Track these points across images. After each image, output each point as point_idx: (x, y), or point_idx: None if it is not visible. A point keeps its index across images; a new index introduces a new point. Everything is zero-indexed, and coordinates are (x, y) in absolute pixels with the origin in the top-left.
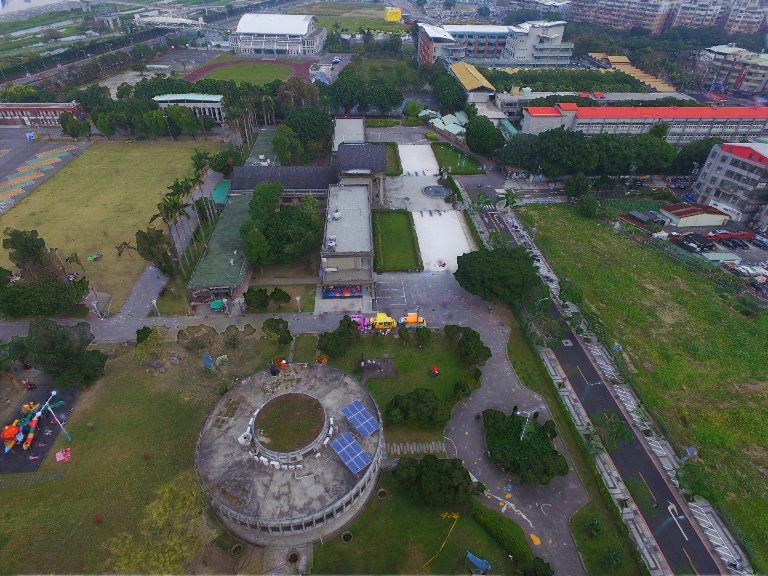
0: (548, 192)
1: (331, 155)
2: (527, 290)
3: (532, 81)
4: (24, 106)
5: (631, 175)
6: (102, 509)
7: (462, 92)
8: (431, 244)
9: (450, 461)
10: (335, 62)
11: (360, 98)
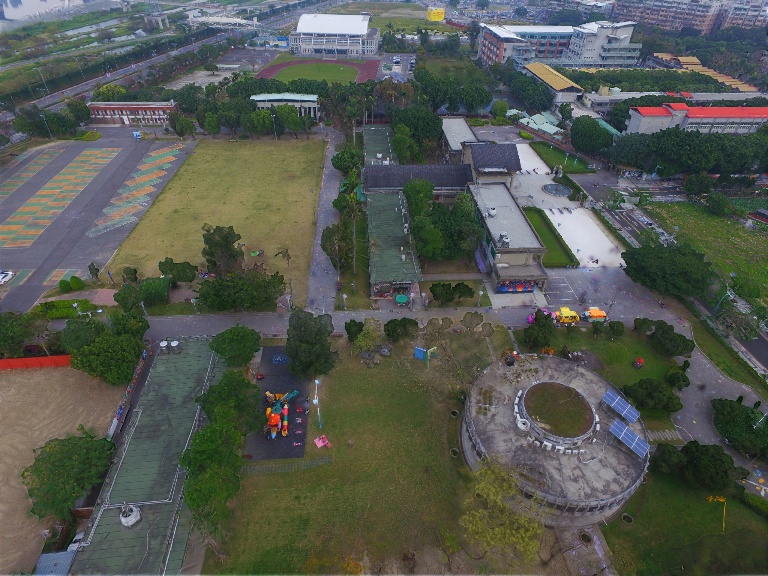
0: (665, 190)
1: (444, 154)
2: (708, 285)
3: (614, 81)
4: (123, 105)
5: (741, 174)
6: (383, 492)
7: (548, 92)
8: (574, 241)
9: (712, 447)
10: (397, 62)
11: (451, 98)
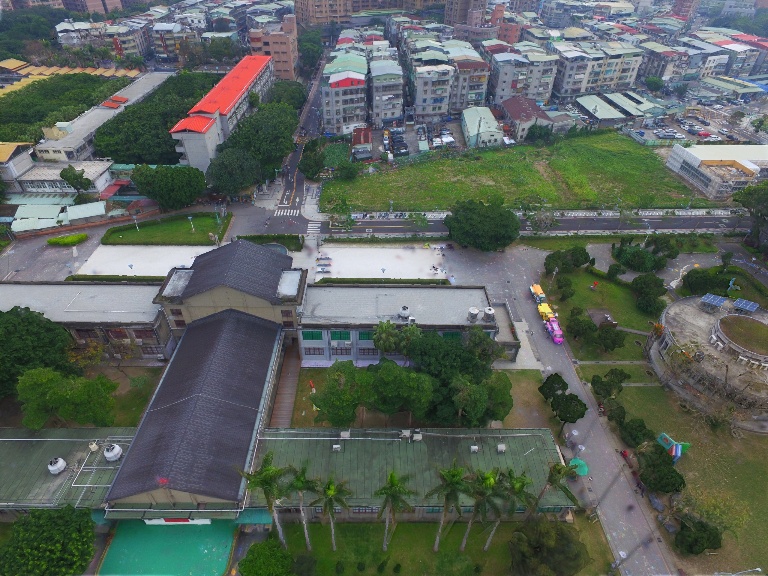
0: (293, 187)
1: None
2: None
3: (17, 118)
4: None
5: None
6: None
7: None
8: (393, 272)
9: (696, 274)
10: None
11: None
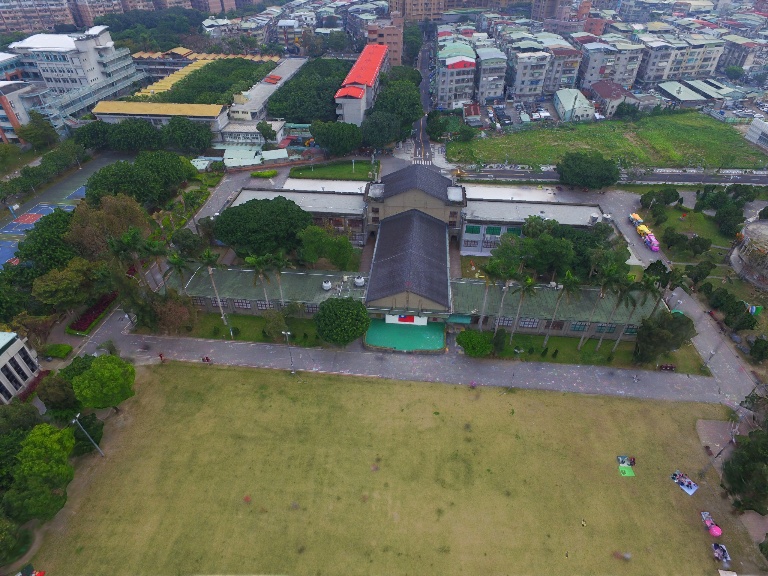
0: (422, 146)
1: None
2: None
3: (207, 89)
4: None
5: None
6: None
7: None
8: None
9: None
10: None
11: None
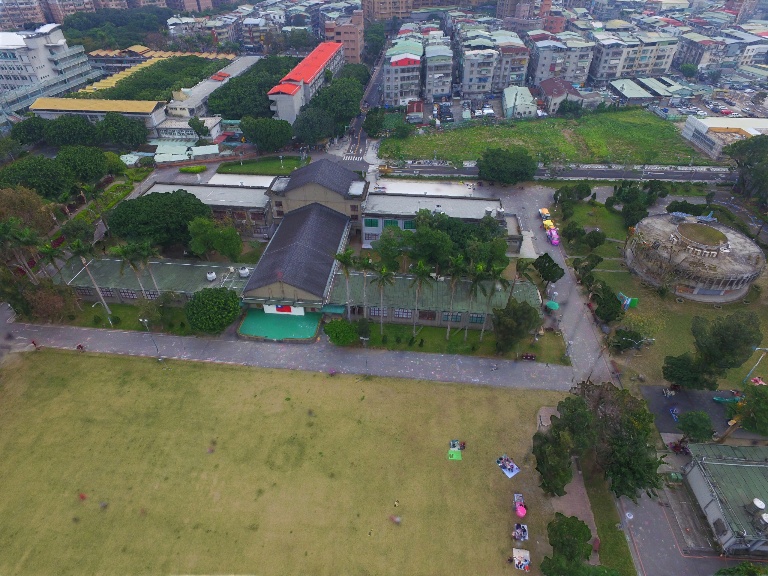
0: (358, 142)
1: None
2: None
3: (151, 86)
4: None
5: None
6: None
7: None
8: None
9: None
10: None
11: None
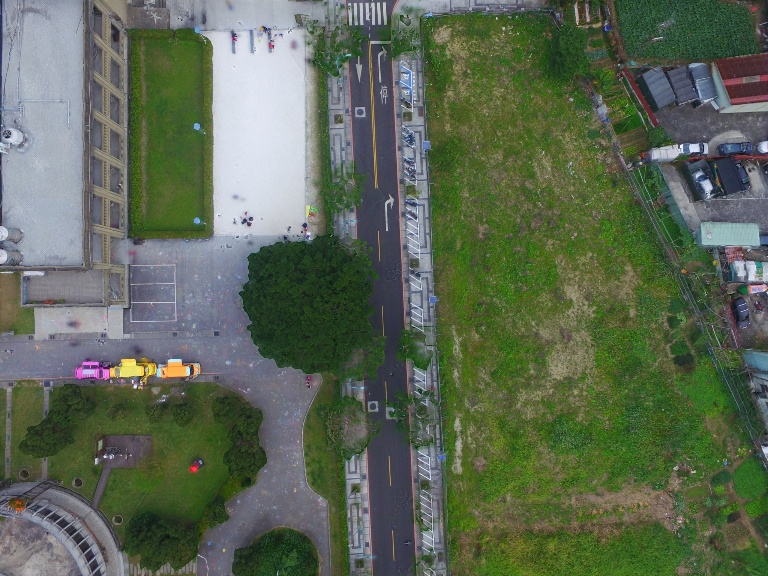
0: None
1: None
2: (339, 362)
3: None
4: None
5: None
6: None
7: None
8: (238, 153)
9: None
10: None
11: None
